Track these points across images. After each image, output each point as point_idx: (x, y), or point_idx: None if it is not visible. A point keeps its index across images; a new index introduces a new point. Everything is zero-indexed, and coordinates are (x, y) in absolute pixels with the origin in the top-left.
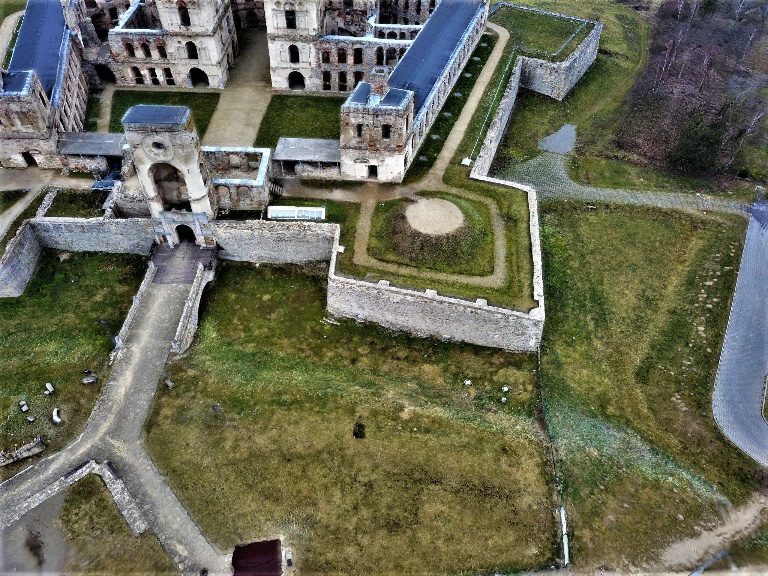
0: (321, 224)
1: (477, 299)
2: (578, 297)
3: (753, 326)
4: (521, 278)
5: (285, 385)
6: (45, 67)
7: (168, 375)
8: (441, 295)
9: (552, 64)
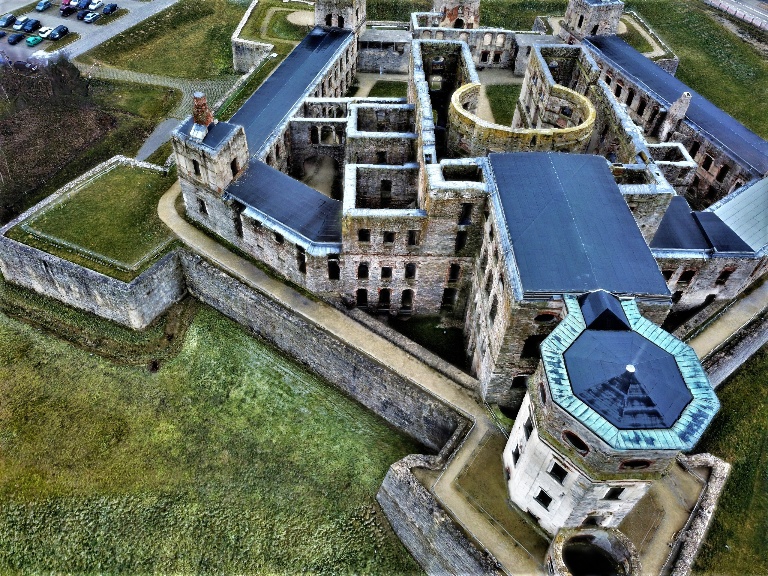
0: (373, 21)
1: (288, 2)
2: (223, 37)
3: (140, 14)
4: (261, 8)
5: (379, 1)
6: (630, 65)
7: (431, 4)
8: (306, 3)
9: (132, 160)
